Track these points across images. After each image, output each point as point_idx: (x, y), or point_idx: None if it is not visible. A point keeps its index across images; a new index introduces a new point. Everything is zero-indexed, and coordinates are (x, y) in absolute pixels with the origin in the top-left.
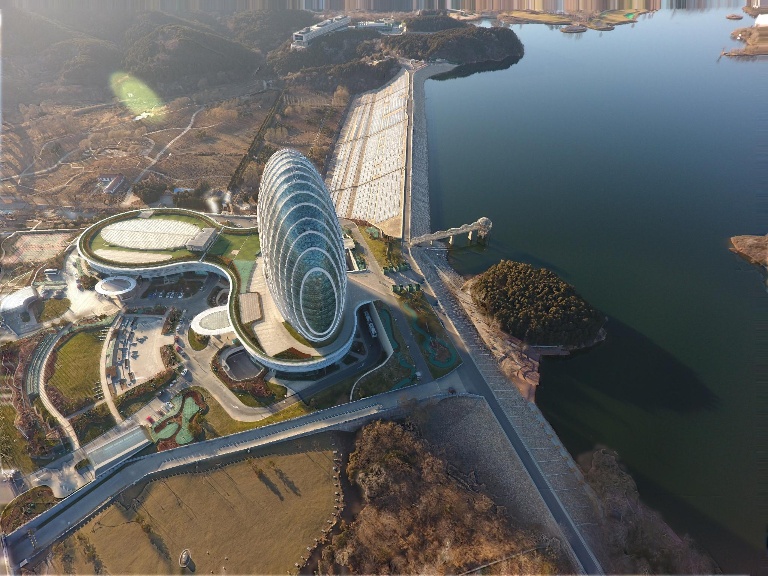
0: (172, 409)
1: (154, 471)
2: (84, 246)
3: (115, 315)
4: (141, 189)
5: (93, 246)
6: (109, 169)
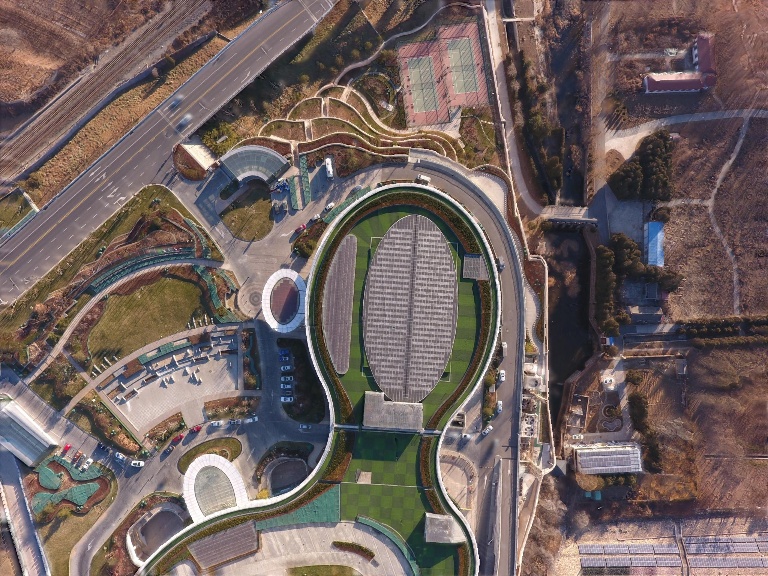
0: (80, 471)
1: (2, 483)
2: (362, 210)
3: (237, 320)
4: (645, 158)
5: (367, 222)
6: (746, 35)
